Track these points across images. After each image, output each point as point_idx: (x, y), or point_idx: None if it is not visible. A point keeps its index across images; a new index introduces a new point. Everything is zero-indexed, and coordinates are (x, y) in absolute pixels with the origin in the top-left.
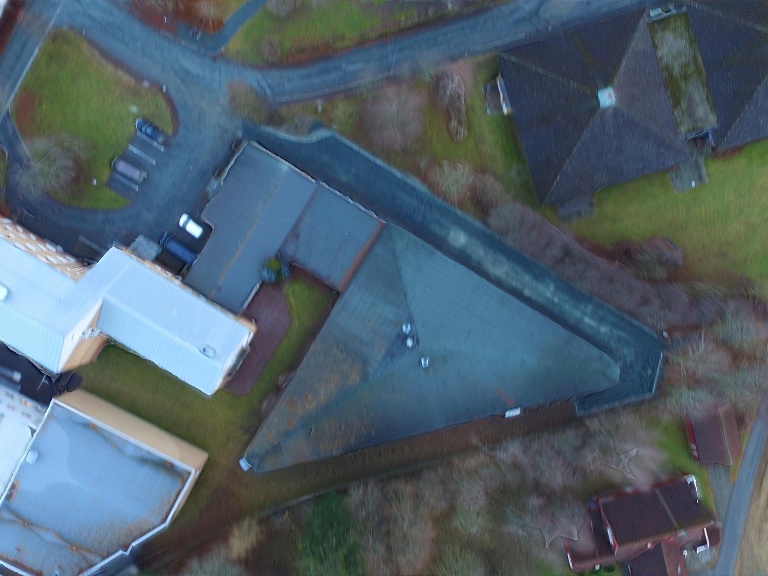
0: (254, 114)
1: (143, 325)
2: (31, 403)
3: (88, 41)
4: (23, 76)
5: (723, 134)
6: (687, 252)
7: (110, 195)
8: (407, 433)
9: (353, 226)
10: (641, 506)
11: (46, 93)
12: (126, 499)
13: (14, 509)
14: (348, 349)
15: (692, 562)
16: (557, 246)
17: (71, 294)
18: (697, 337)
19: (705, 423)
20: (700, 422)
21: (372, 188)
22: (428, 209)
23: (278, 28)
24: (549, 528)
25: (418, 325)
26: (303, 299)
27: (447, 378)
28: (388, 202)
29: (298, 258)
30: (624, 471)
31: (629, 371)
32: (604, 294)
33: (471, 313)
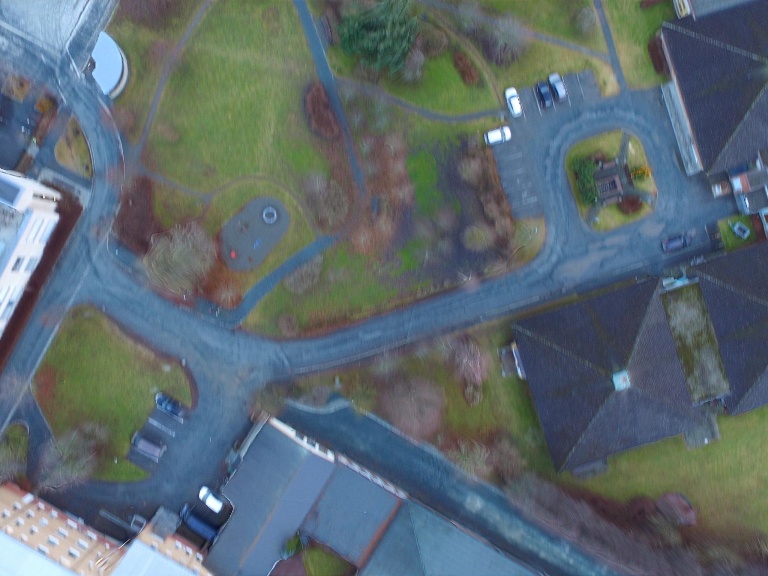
0: (272, 386)
1: None
2: None
3: (108, 317)
4: (44, 352)
5: (736, 402)
6: (700, 507)
7: (130, 468)
8: None
9: (371, 504)
10: None
11: (67, 369)
12: None
13: None
14: None
15: None
16: (573, 528)
17: None
18: None
19: None
20: None
21: (389, 456)
22: (445, 476)
23: (296, 302)
24: None
25: None
26: (322, 566)
27: None
28: (405, 470)
29: (317, 536)
30: None
31: None
32: None
33: None
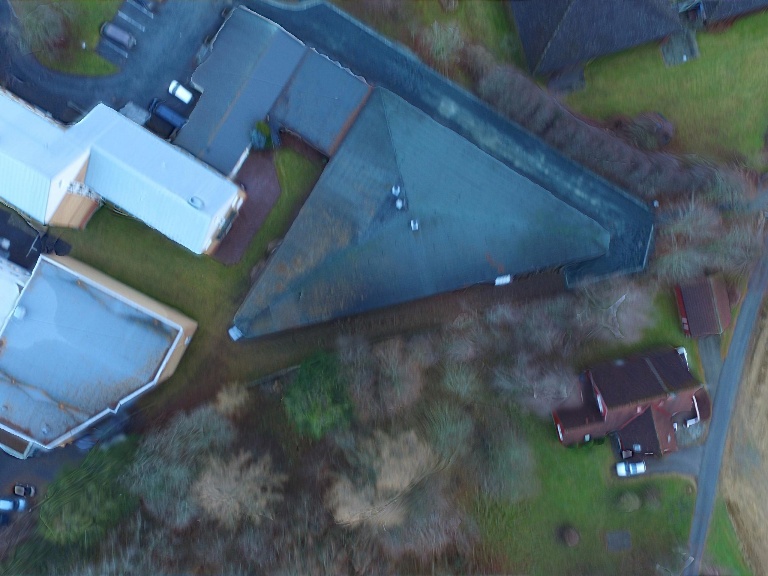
0: None
1: (131, 177)
2: (20, 269)
3: None
4: None
5: (714, 3)
6: (678, 127)
7: (99, 61)
8: (396, 298)
9: (343, 90)
10: (631, 374)
11: None
12: (114, 357)
13: (2, 366)
14: (337, 212)
15: (682, 437)
16: (547, 108)
17: (58, 141)
18: (687, 197)
19: (695, 292)
20: (690, 291)
21: (362, 57)
22: (418, 78)
23: None
24: (537, 377)
25: (408, 188)
26: (293, 168)
27: (437, 242)
28: (378, 71)
29: (288, 122)
30: (613, 326)
31: (620, 244)
32: (595, 163)
33: (461, 177)
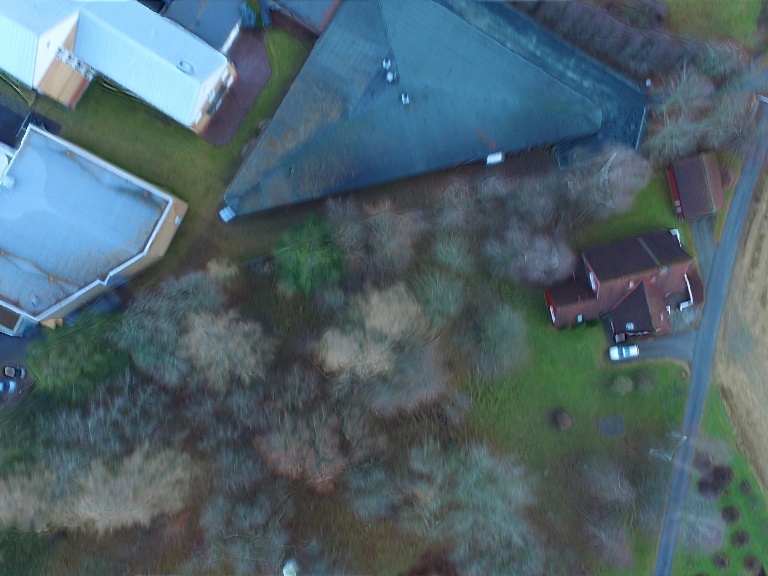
0: None
1: (120, 41)
2: None
3: None
4: None
5: None
6: (671, 11)
7: None
8: (388, 175)
9: None
10: (623, 252)
11: None
12: (103, 228)
13: None
14: (328, 87)
15: (676, 322)
16: None
17: (47, 3)
18: (679, 68)
19: (688, 170)
20: (683, 170)
21: None
22: None
23: None
24: (528, 239)
25: (398, 61)
26: (284, 48)
27: (428, 117)
28: None
29: None
30: (605, 193)
31: (612, 126)
32: (586, 42)
33: (452, 52)
